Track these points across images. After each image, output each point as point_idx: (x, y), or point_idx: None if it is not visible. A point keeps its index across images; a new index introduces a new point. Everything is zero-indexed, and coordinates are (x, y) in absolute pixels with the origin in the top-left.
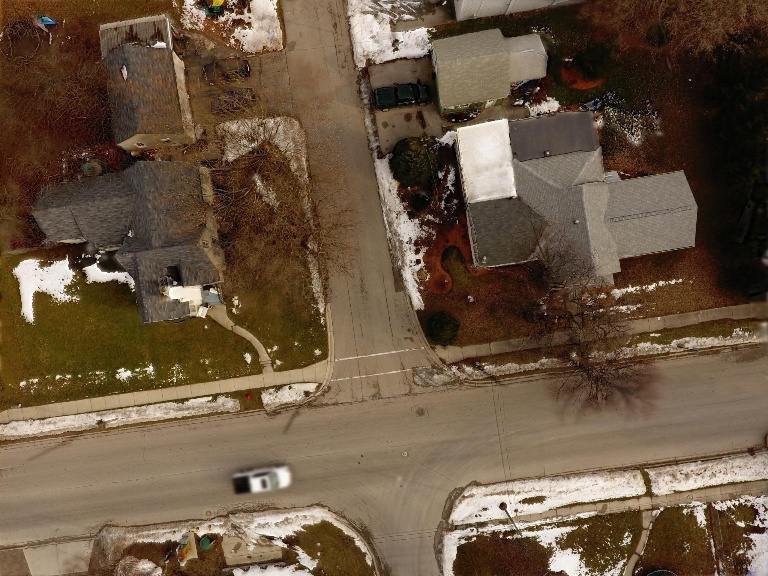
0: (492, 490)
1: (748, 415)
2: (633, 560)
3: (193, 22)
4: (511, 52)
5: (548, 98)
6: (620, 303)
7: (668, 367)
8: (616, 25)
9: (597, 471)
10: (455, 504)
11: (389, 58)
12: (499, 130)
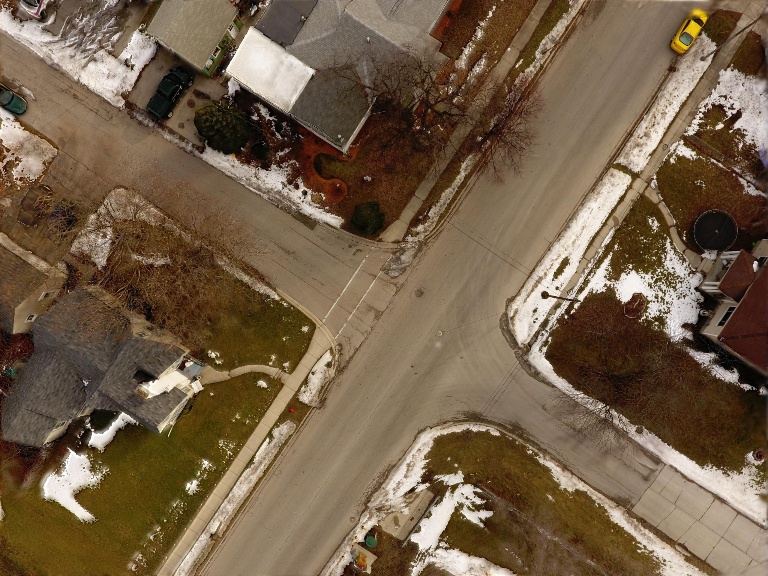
0: (525, 292)
1: (642, 47)
2: (673, 233)
3: None
4: None
5: None
6: (469, 68)
7: (552, 76)
8: None
9: (583, 201)
10: (511, 330)
11: (135, 78)
12: (254, 40)
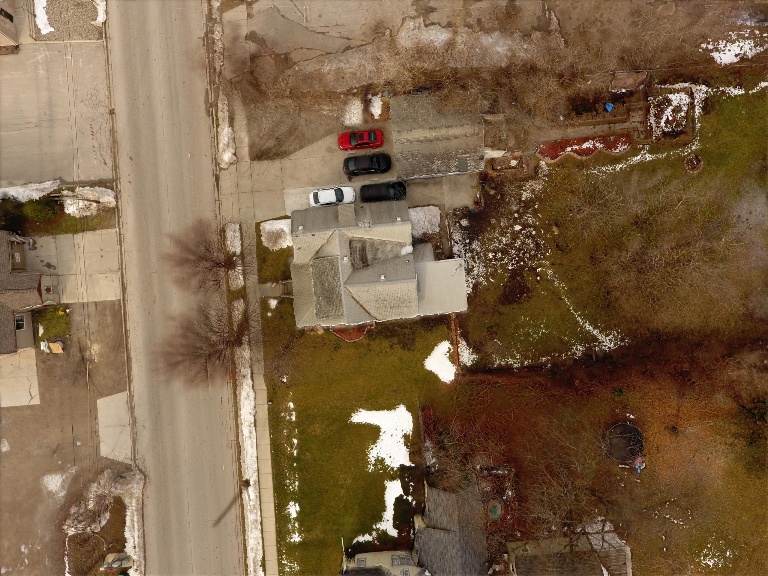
0: None
1: None
2: None
3: None
4: None
5: None
6: None
7: None
8: None
9: None
10: None
11: None
12: None
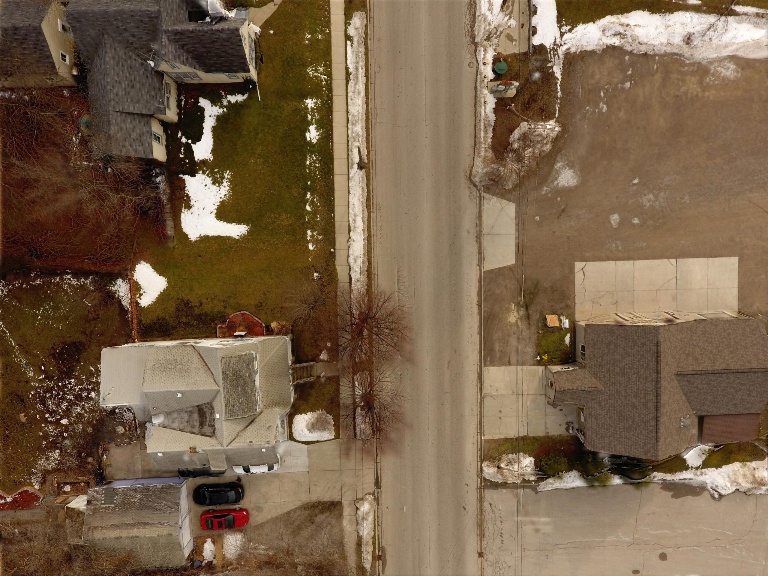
0: None
1: None
2: None
3: None
4: None
5: None
6: None
7: None
8: None
9: None
10: None
11: None
12: None
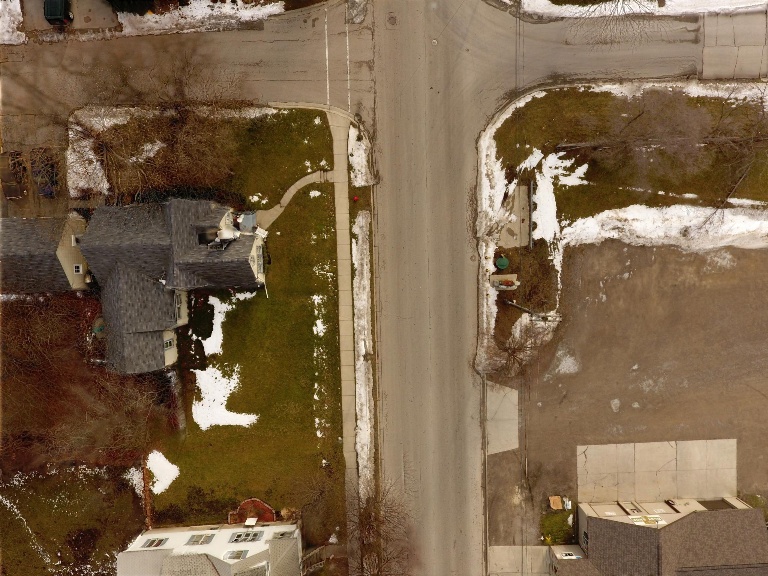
0: None
1: None
2: None
3: None
4: None
5: None
6: None
7: None
8: None
9: None
10: None
11: (18, 6)
12: None
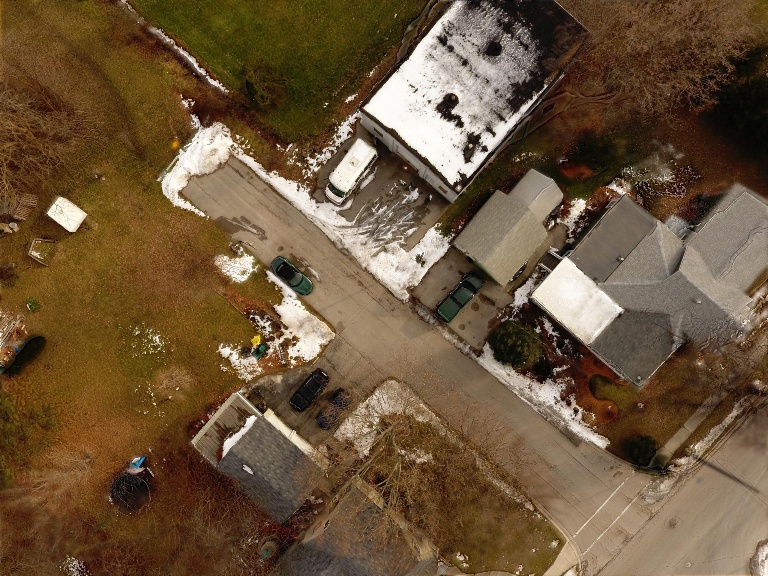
0: None
1: None
2: None
3: (250, 372)
4: (529, 207)
5: (571, 203)
6: (764, 317)
7: None
8: (596, 122)
9: None
10: (760, 571)
11: (422, 274)
12: (567, 271)
